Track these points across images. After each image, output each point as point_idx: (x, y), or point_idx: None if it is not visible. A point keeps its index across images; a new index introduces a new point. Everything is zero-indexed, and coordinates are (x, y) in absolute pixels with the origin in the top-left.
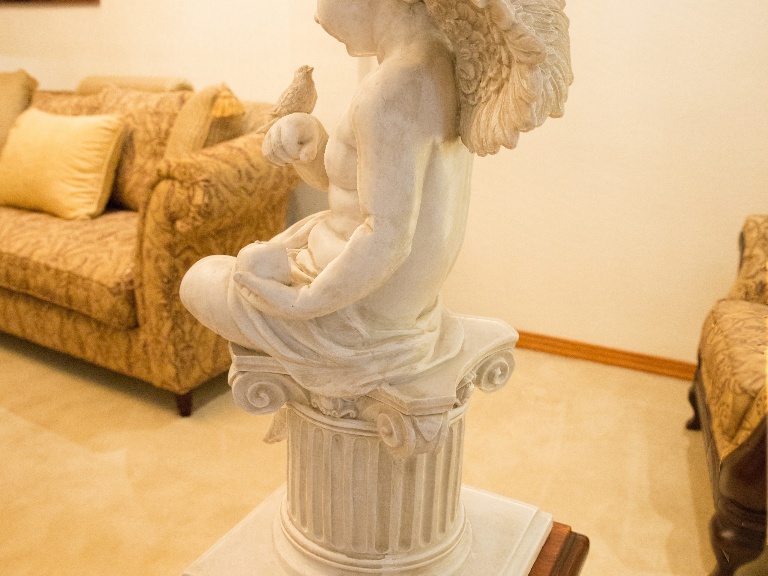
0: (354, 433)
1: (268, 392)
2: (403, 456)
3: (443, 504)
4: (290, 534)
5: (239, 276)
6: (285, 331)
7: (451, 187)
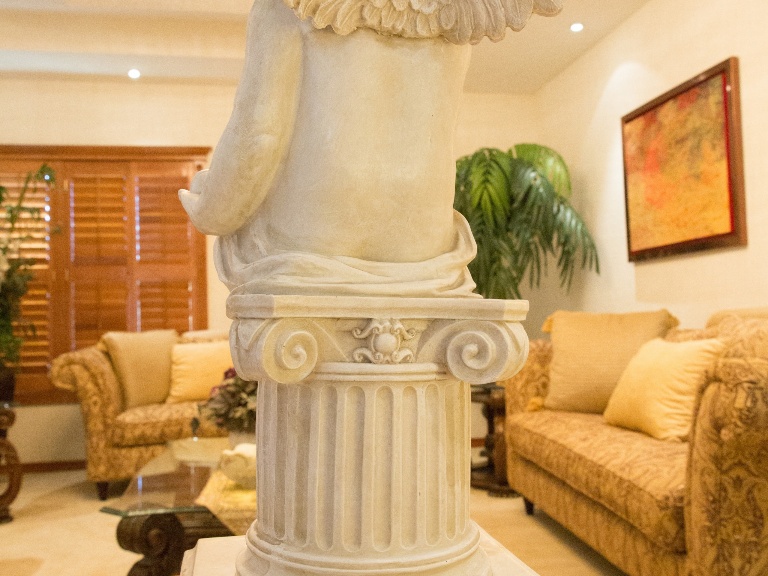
0: None
1: None
2: None
3: (358, 502)
4: None
5: None
6: None
7: (333, 81)
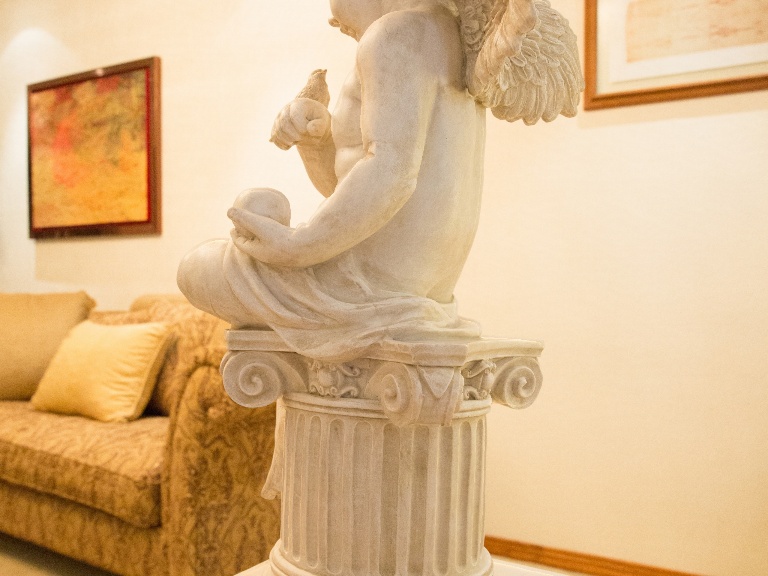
0: (355, 414)
1: (262, 377)
2: (408, 420)
3: (462, 526)
4: (280, 568)
5: (233, 210)
6: (282, 290)
7: (459, 137)
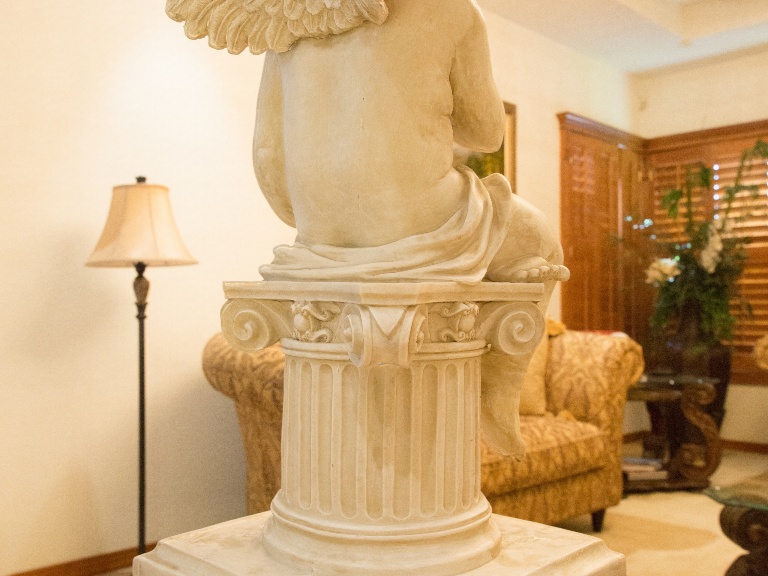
0: None
1: None
2: None
3: None
4: None
5: None
6: None
7: (287, 93)
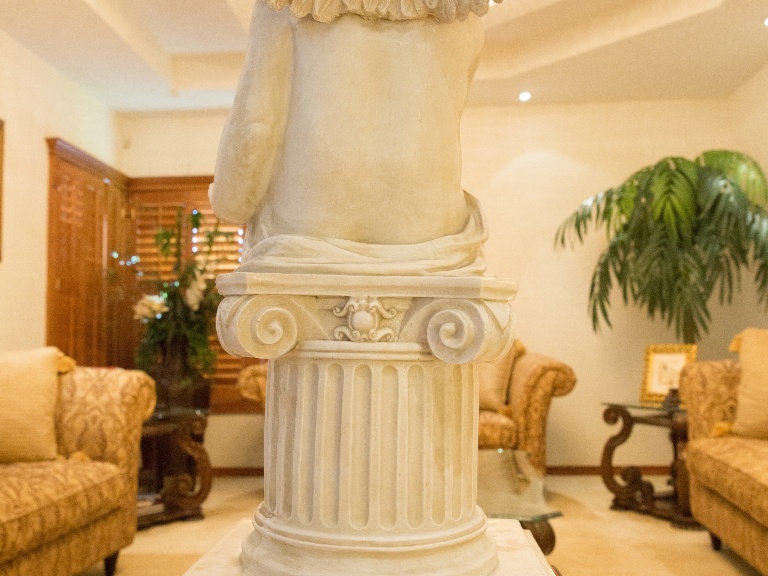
0: None
1: None
2: None
3: (337, 478)
4: None
5: None
6: None
7: (318, 68)
